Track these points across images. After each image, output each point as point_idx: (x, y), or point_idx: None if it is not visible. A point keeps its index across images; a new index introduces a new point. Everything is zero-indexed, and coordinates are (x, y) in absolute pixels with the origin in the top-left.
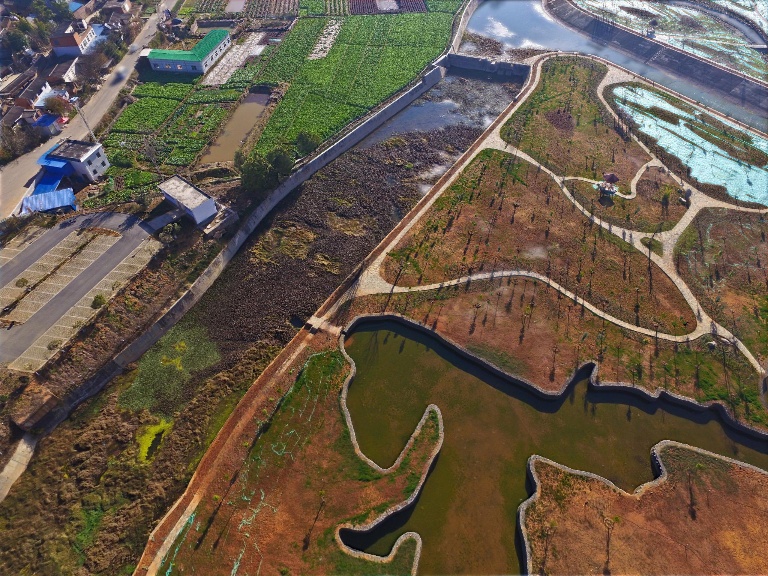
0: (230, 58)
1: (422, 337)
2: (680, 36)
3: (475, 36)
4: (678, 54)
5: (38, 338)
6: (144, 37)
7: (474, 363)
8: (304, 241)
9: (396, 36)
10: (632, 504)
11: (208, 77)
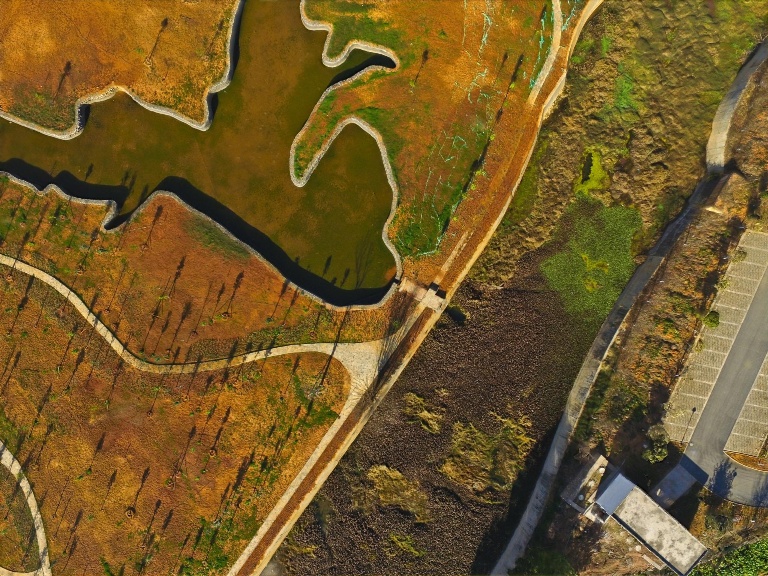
0: None
1: (303, 282)
2: None
3: None
4: None
5: (764, 277)
6: None
7: None
8: (459, 459)
9: None
10: (121, 78)
11: None
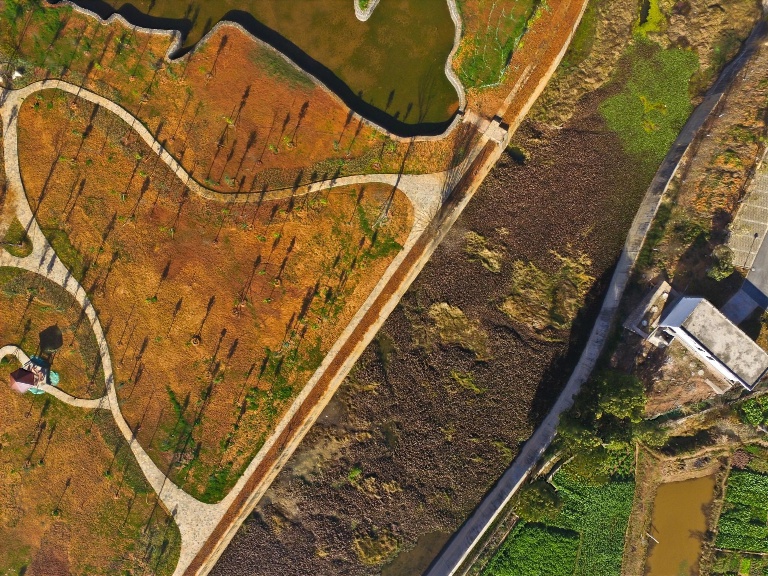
0: None
1: None
2: None
3: None
4: None
5: None
6: None
7: None
8: (519, 297)
9: None
10: None
11: None
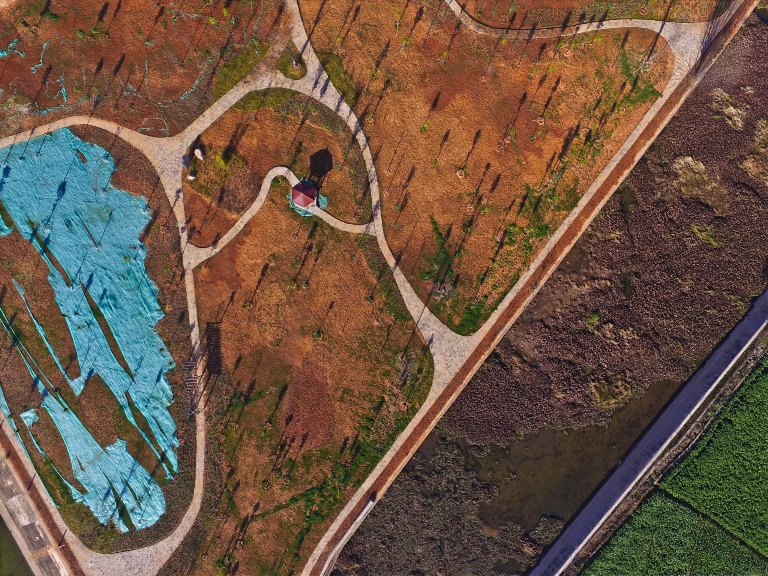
0: None
1: None
2: None
3: None
4: None
5: None
6: None
7: None
8: (760, 156)
9: None
10: None
11: None
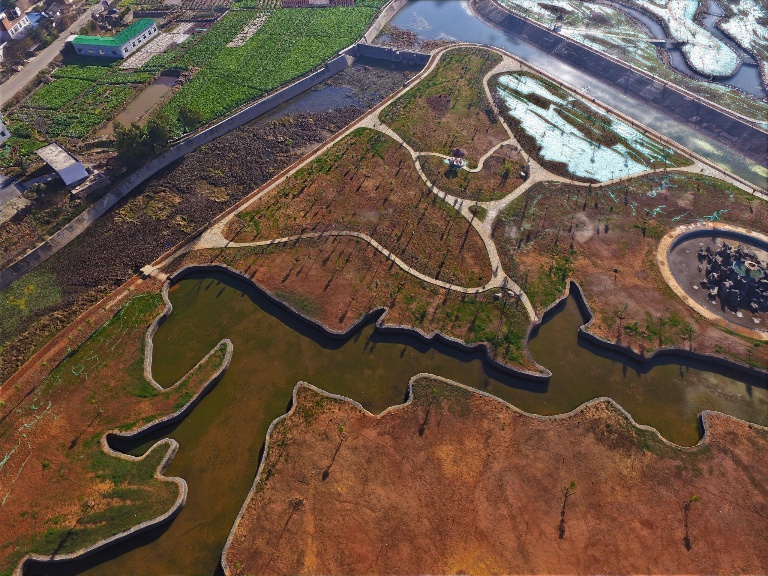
0: (153, 45)
1: (244, 286)
2: (585, 30)
3: (394, 29)
4: (576, 47)
5: None
6: (78, 25)
7: (281, 308)
8: (169, 204)
9: (315, 27)
10: (371, 422)
11: (127, 61)
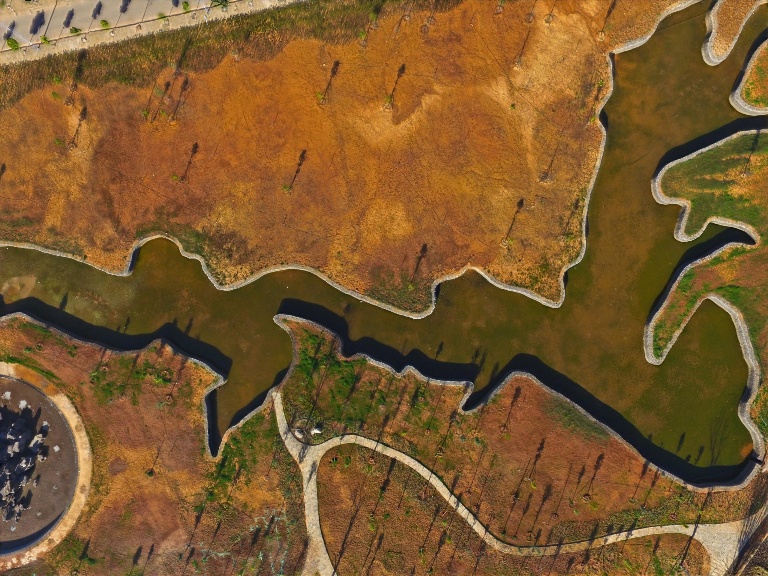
0: None
1: (652, 457)
2: None
3: None
4: None
5: None
6: None
7: None
8: None
9: None
10: (477, 259)
11: None
